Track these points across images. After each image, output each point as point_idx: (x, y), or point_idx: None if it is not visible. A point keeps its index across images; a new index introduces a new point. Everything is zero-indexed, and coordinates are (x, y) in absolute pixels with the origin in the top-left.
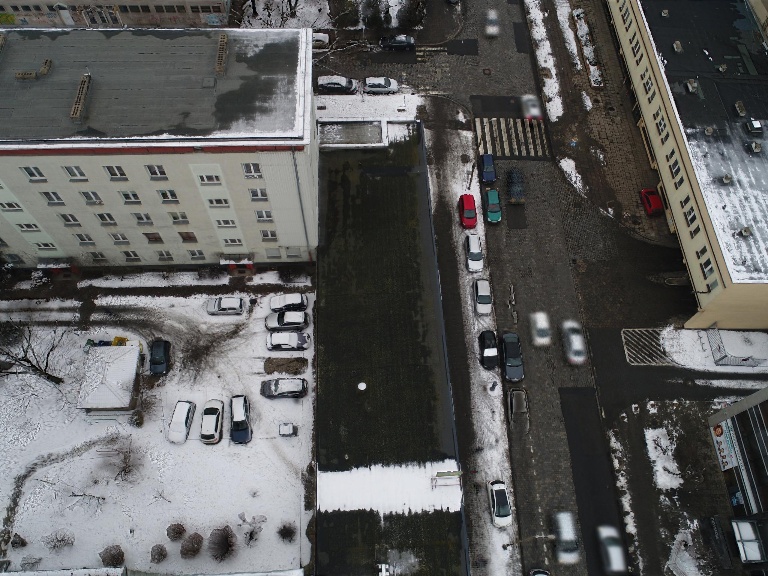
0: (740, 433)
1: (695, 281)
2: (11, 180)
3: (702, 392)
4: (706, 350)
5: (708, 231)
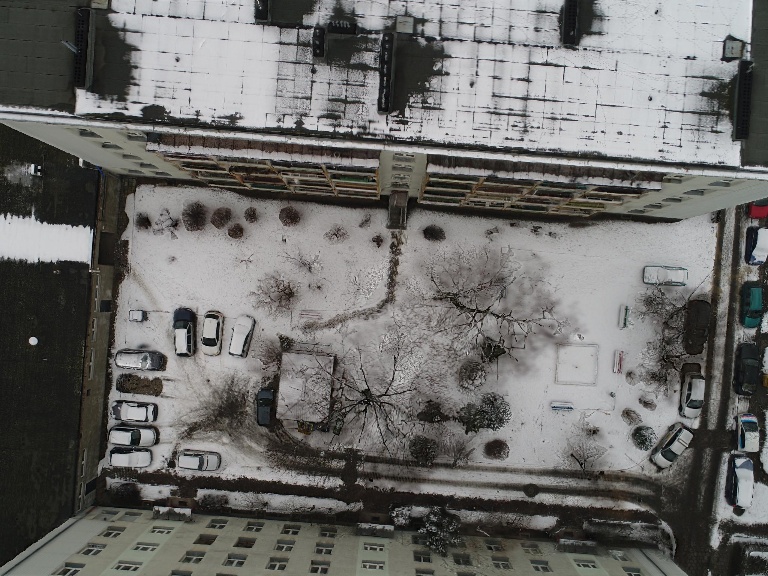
0: None
1: None
2: None
3: None
4: None
5: None
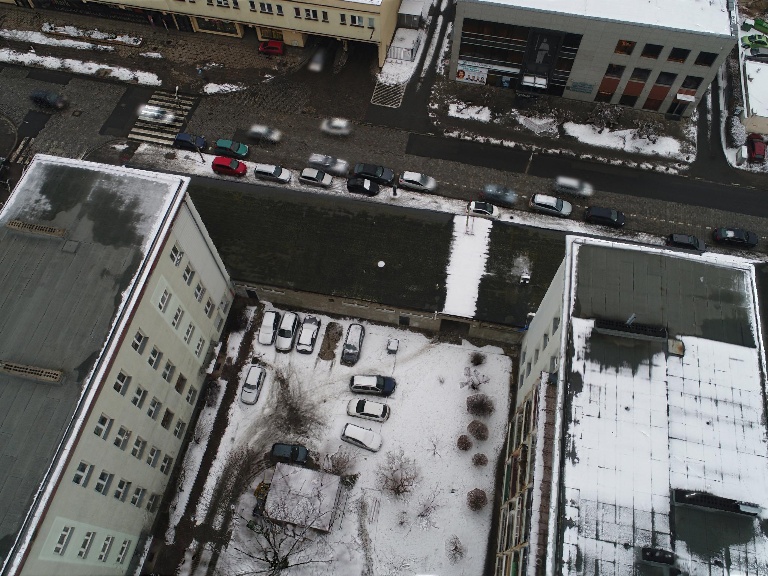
0: (471, 57)
1: (359, 37)
2: (74, 508)
3: (430, 76)
4: (402, 62)
5: (333, 5)
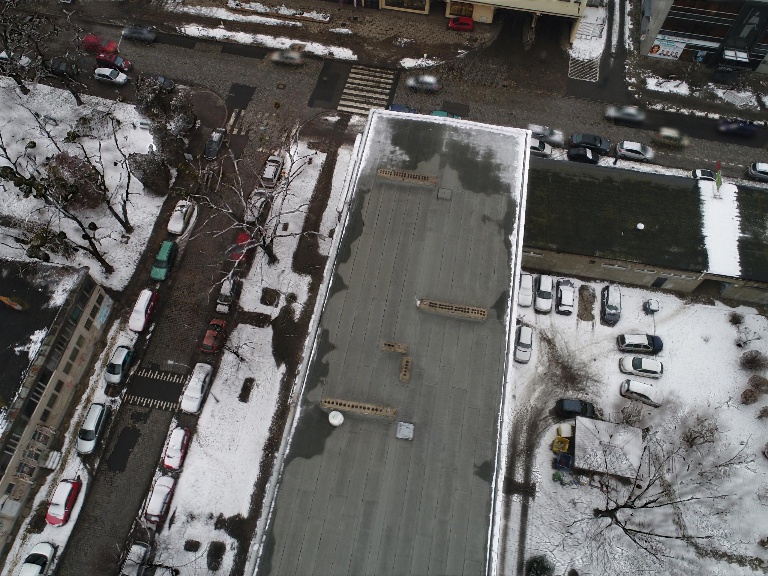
0: (673, 31)
1: (561, 12)
2: None
3: (621, 51)
4: None
5: None
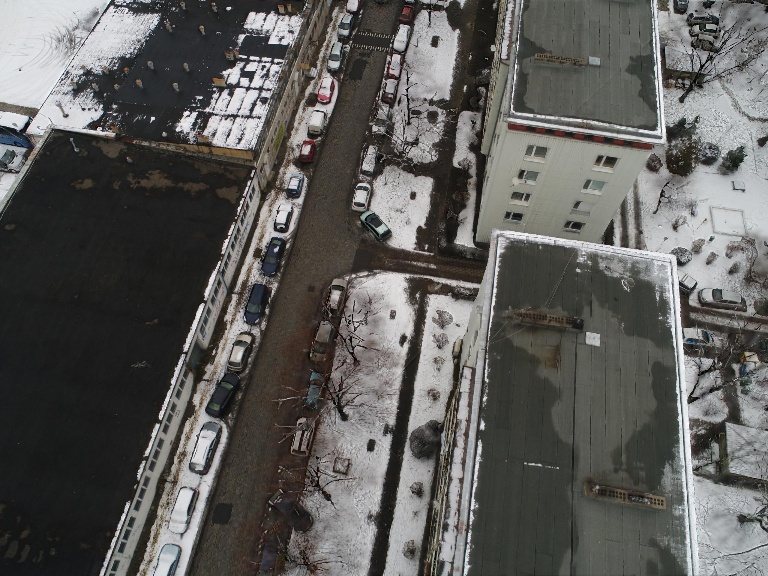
0: None
1: None
2: None
3: None
4: None
5: None
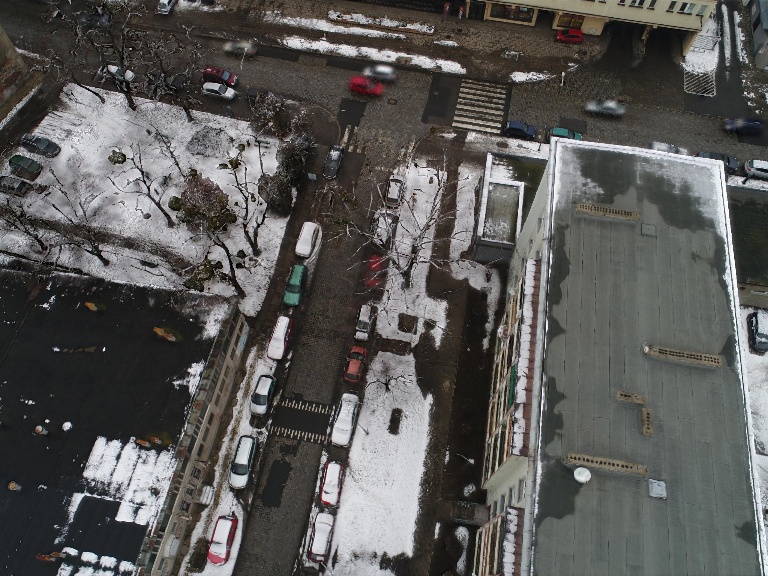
0: None
1: (680, 25)
2: None
3: (735, 65)
4: None
5: None
